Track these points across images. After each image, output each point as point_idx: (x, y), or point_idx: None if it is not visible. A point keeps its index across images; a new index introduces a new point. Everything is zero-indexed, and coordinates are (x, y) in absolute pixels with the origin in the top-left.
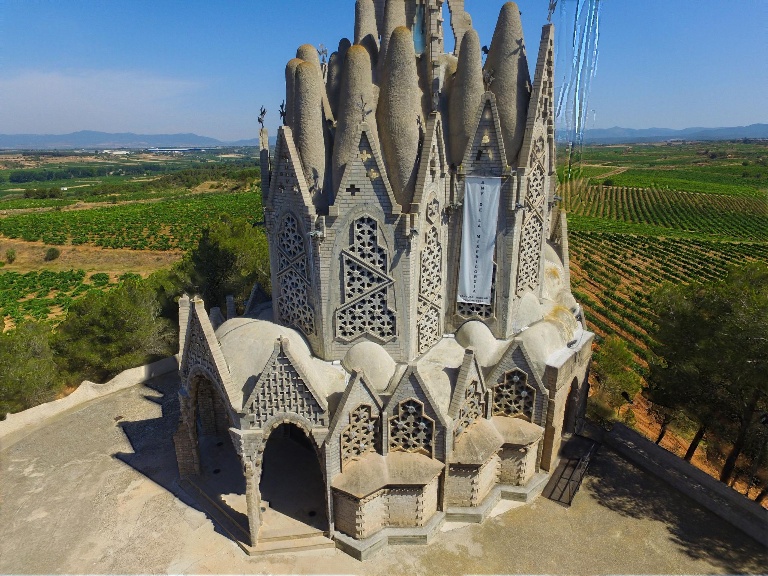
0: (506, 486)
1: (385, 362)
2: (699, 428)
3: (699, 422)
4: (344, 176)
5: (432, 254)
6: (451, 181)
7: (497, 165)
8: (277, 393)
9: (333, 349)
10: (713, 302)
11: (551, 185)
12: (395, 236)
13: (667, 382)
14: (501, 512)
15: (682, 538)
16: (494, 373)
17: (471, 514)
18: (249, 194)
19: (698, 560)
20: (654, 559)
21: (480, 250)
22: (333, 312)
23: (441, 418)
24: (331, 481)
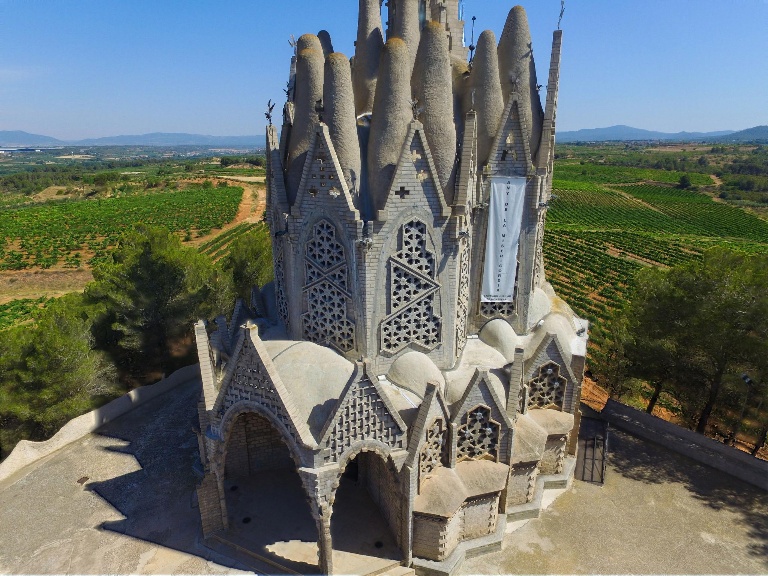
0: (547, 476)
1: (435, 371)
2: (653, 394)
3: (673, 389)
4: (396, 178)
5: (464, 256)
6: (477, 181)
7: (521, 165)
8: (355, 420)
9: (377, 364)
10: (697, 283)
11: (549, 184)
12: (443, 239)
13: (643, 357)
14: (550, 502)
15: (700, 494)
16: (530, 368)
17: (530, 510)
18: (114, 200)
19: (720, 510)
20: (690, 517)
21: (505, 249)
22: (378, 324)
23: (507, 420)
24: (413, 506)
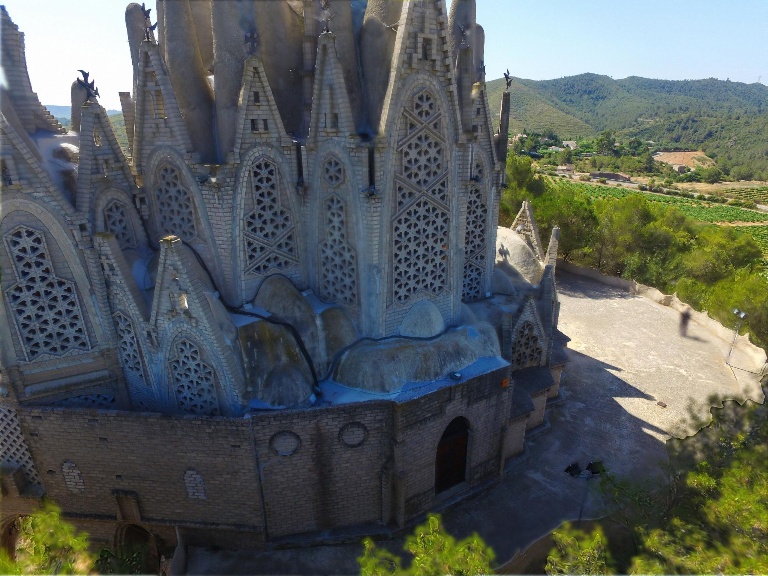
0: None
1: None
2: None
3: None
4: None
5: None
6: None
7: None
8: None
9: None
10: None
11: None
12: None
13: None
14: None
15: None
16: None
17: None
18: None
19: None
20: None
21: None
22: None
23: None
24: None
